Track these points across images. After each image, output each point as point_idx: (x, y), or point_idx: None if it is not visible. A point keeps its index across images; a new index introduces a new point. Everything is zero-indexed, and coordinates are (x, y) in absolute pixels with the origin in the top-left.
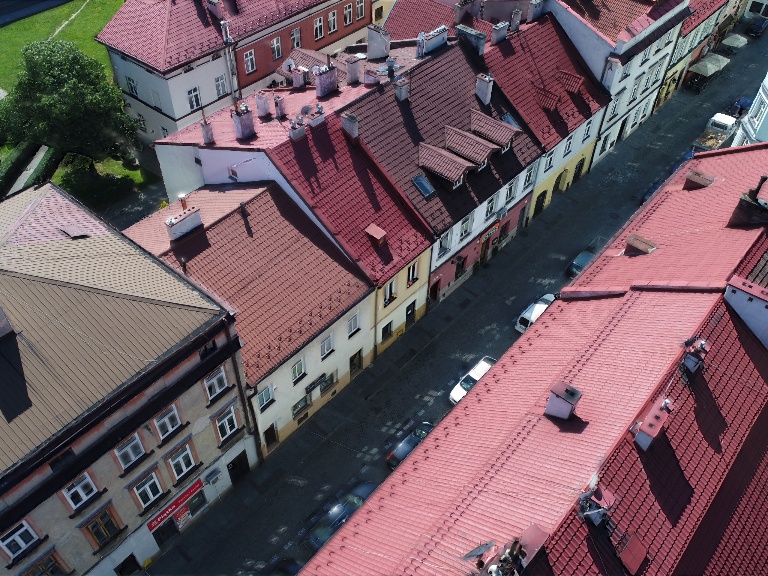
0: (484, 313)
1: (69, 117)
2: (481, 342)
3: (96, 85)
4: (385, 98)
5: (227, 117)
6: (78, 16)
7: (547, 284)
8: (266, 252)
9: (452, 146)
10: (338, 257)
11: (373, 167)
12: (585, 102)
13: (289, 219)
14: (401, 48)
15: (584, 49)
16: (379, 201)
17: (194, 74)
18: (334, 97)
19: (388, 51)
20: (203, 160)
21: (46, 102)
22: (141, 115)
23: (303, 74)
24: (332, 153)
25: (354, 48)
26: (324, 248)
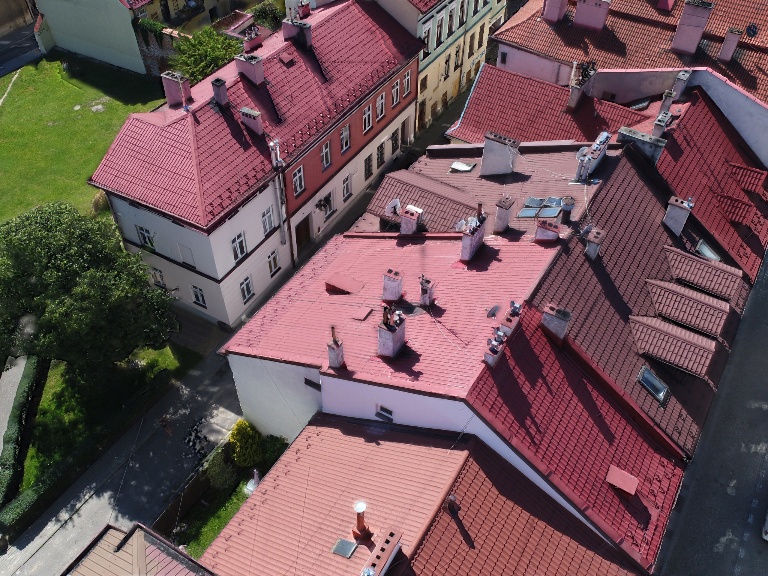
0: (708, 515)
1: (89, 326)
2: (725, 567)
3: (112, 261)
4: (574, 260)
5: (320, 293)
6: (6, 102)
7: (765, 452)
8: (499, 569)
9: (666, 311)
10: (589, 540)
11: (588, 373)
12: (763, 200)
13: (511, 496)
14: (521, 155)
15: (748, 130)
16: (608, 425)
17: (239, 217)
18: (493, 262)
19: (513, 165)
20: (326, 388)
21: (55, 314)
22: (158, 269)
23: (416, 217)
24: (539, 369)
25: (439, 151)
26: (568, 531)
